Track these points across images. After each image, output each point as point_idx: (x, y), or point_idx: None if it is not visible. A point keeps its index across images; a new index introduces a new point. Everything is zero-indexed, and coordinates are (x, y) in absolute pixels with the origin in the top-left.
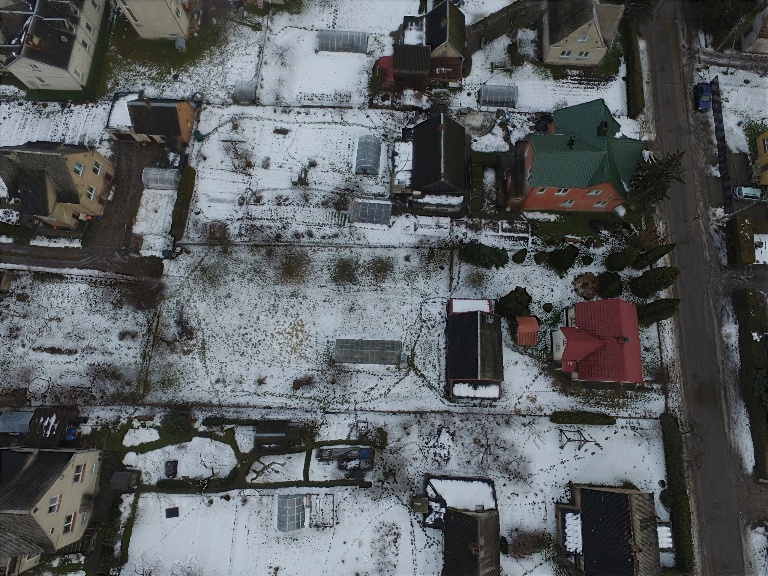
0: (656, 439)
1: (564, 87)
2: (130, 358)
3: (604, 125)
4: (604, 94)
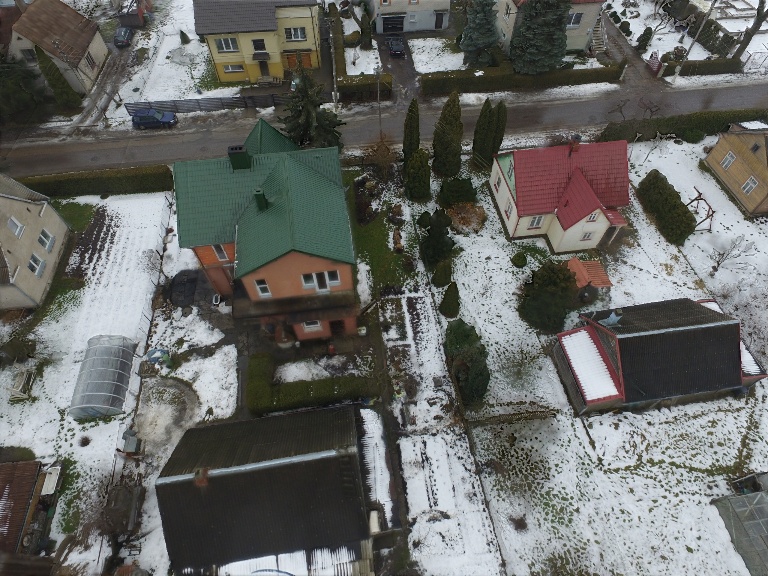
0: None
1: (103, 272)
2: None
3: (236, 150)
4: (129, 218)
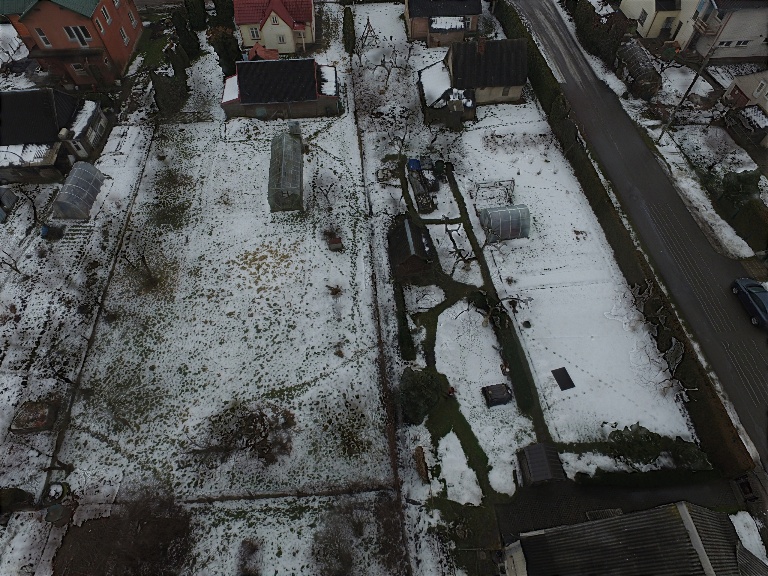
0: (361, 7)
1: None
2: (302, 543)
3: None
4: (3, 34)
